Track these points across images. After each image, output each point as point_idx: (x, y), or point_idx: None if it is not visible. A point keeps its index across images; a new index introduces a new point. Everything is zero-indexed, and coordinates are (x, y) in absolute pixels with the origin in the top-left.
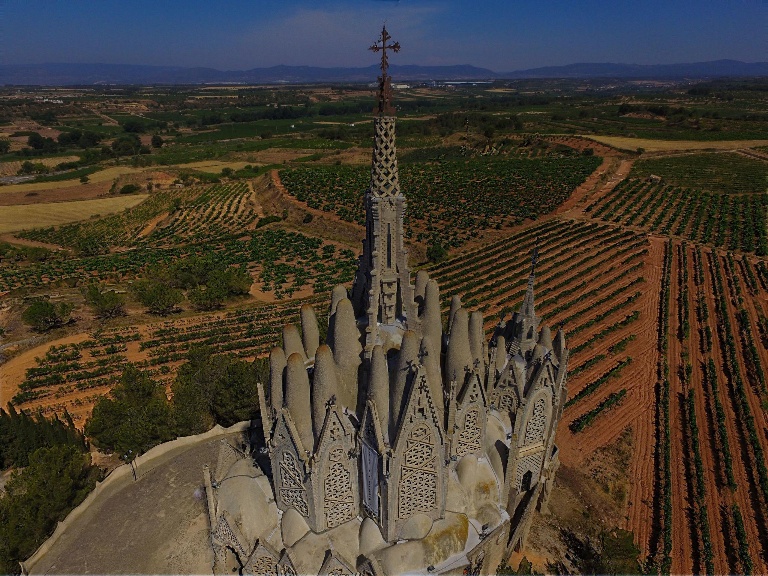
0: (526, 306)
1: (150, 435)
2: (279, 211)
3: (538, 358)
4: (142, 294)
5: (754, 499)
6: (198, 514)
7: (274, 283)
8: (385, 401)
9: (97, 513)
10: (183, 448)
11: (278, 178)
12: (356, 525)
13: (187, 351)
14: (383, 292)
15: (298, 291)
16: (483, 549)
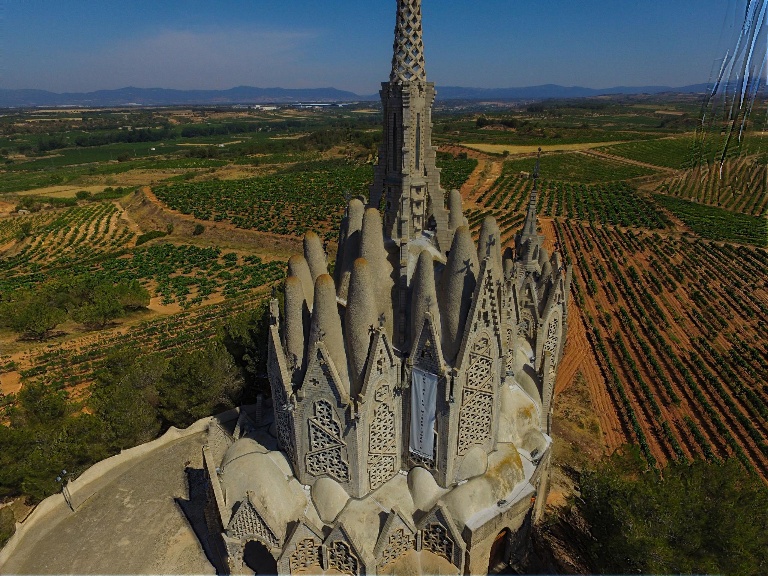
0: (530, 224)
1: (76, 458)
2: (161, 226)
3: (549, 275)
4: (11, 316)
5: (695, 410)
6: (176, 530)
7: (175, 295)
8: (437, 316)
9: (25, 563)
10: (130, 463)
11: (152, 194)
12: (402, 480)
13: (89, 371)
14: (411, 199)
15: (206, 300)
16: (539, 475)
